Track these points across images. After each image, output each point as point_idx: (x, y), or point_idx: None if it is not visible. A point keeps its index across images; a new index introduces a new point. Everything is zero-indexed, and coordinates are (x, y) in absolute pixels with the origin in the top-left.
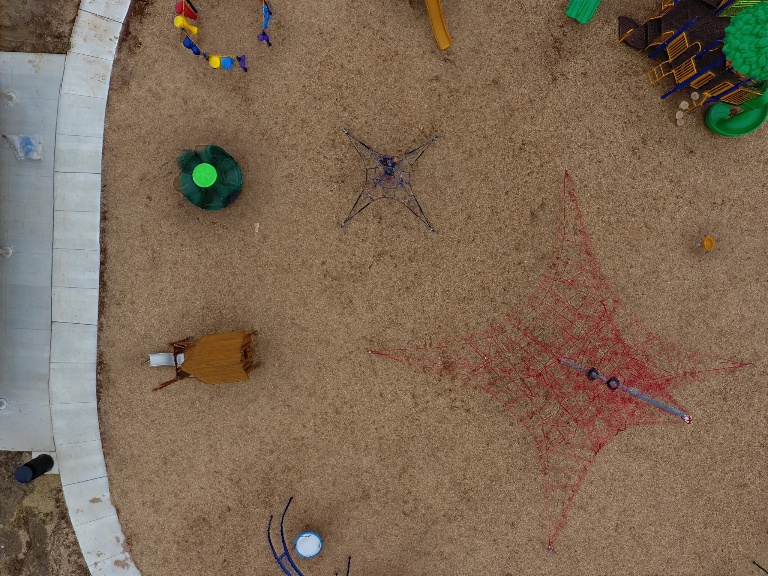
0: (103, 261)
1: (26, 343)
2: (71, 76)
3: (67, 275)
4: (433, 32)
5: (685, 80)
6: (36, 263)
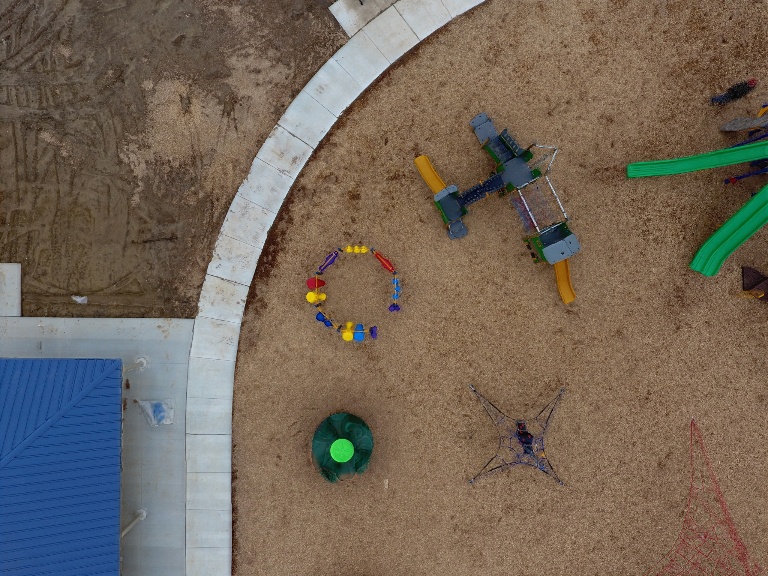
0: (235, 519)
1: None
2: (200, 340)
3: (200, 535)
4: (559, 290)
5: None
6: (170, 524)
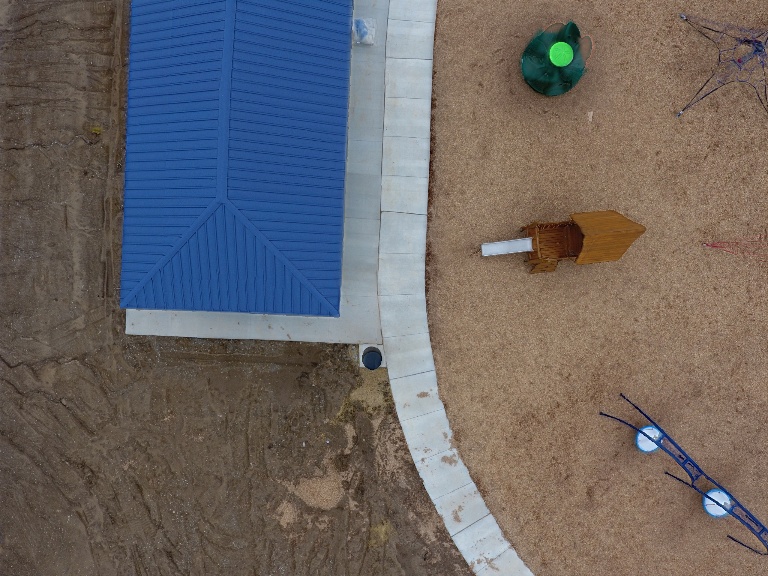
0: (432, 150)
1: (355, 233)
2: None
3: (397, 163)
4: None
5: None
6: (366, 151)
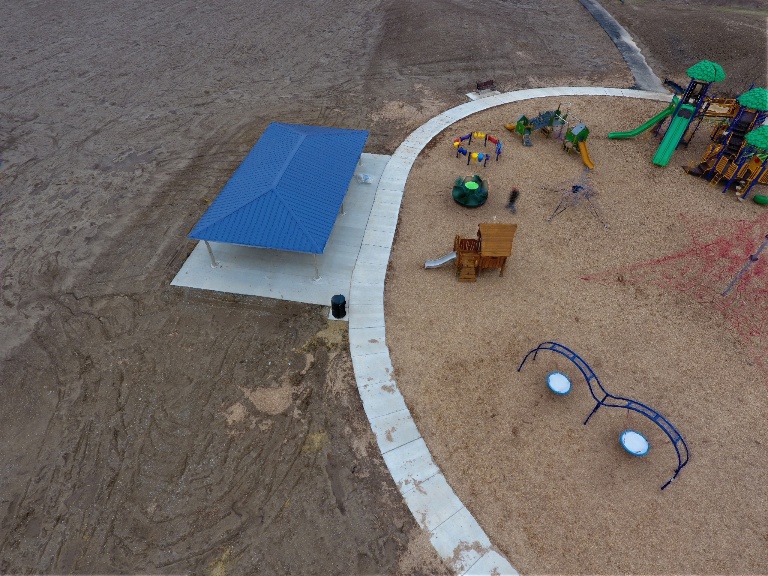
0: (398, 223)
1: (343, 251)
2: (393, 161)
3: (376, 226)
4: (584, 161)
5: (733, 174)
6: (358, 219)
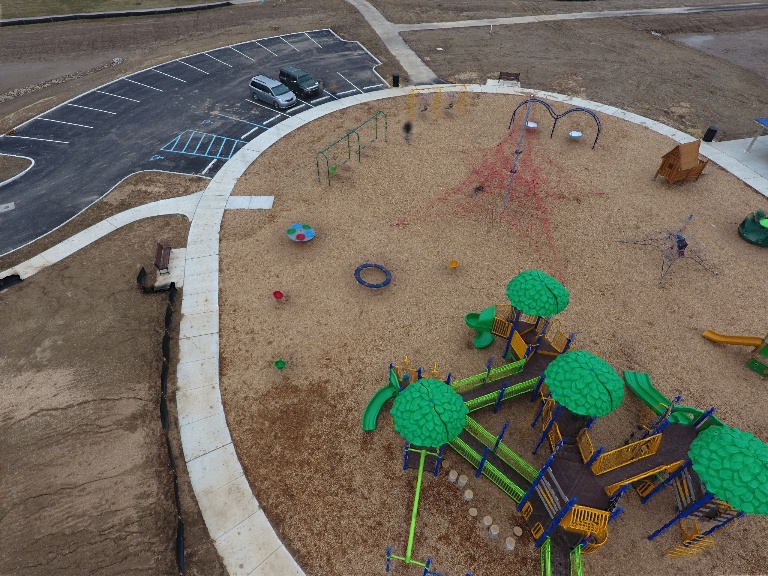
0: None
1: (763, 169)
2: None
3: None
4: None
5: None
6: None
